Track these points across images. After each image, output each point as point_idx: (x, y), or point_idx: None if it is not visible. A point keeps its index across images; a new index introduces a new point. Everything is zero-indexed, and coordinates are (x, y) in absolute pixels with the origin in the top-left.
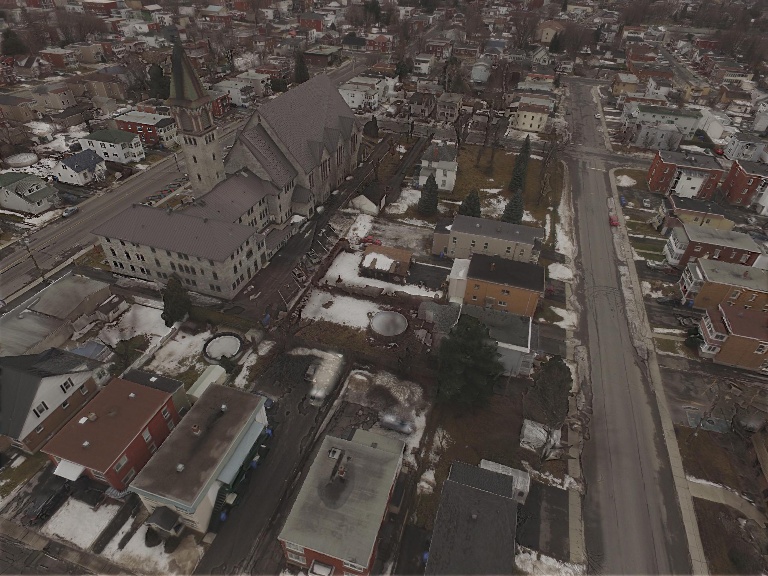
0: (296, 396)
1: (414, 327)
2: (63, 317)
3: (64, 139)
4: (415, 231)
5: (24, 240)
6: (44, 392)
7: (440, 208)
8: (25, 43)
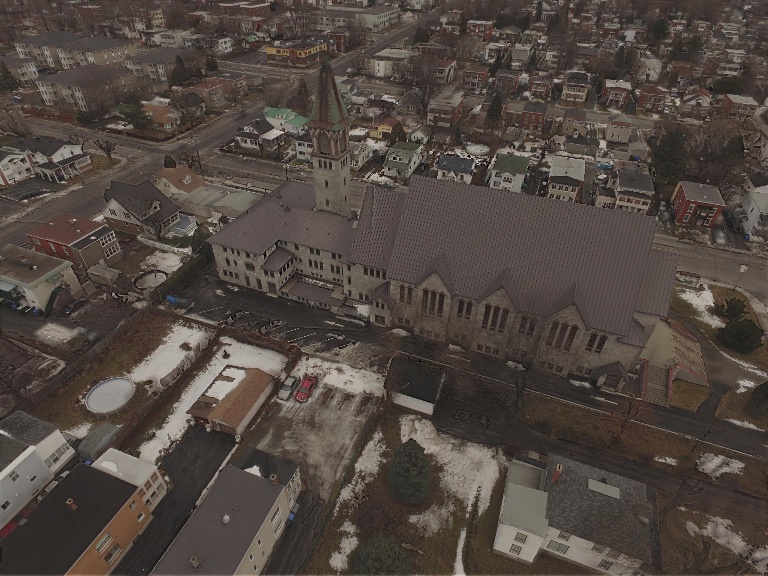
0: (66, 326)
1: (97, 425)
2: (212, 204)
3: (532, 155)
4: (333, 454)
5: (285, 165)
6: (115, 206)
7: (429, 517)
8: (743, 85)
